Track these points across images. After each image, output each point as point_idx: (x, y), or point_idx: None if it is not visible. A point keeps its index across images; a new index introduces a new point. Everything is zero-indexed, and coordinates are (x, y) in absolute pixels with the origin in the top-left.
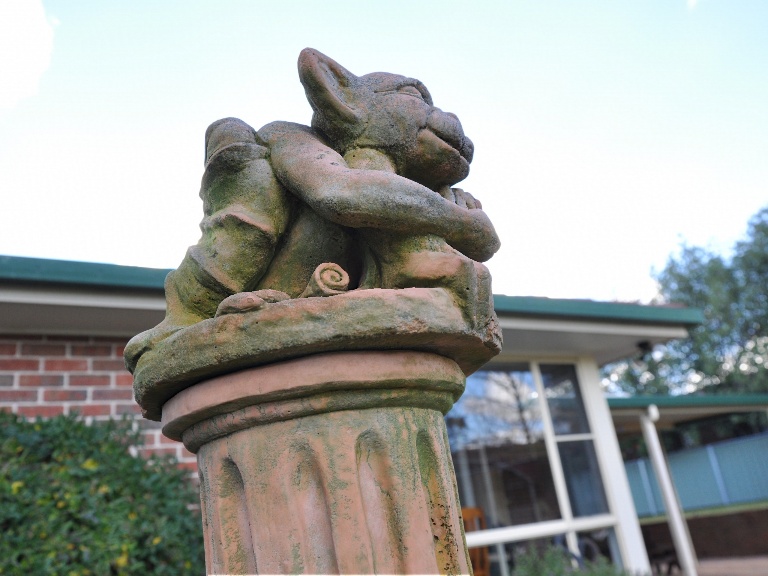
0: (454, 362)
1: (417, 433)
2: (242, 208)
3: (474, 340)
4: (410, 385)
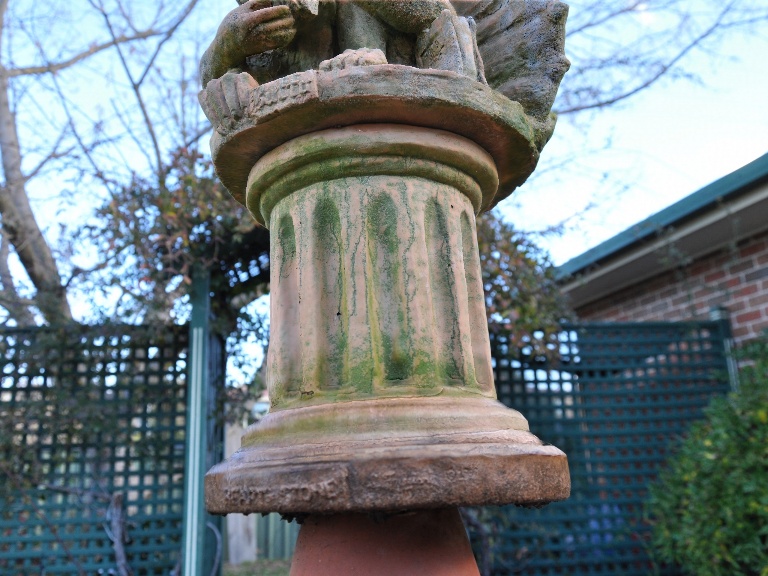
0: (287, 143)
1: (280, 220)
2: None
3: (246, 134)
4: (257, 192)
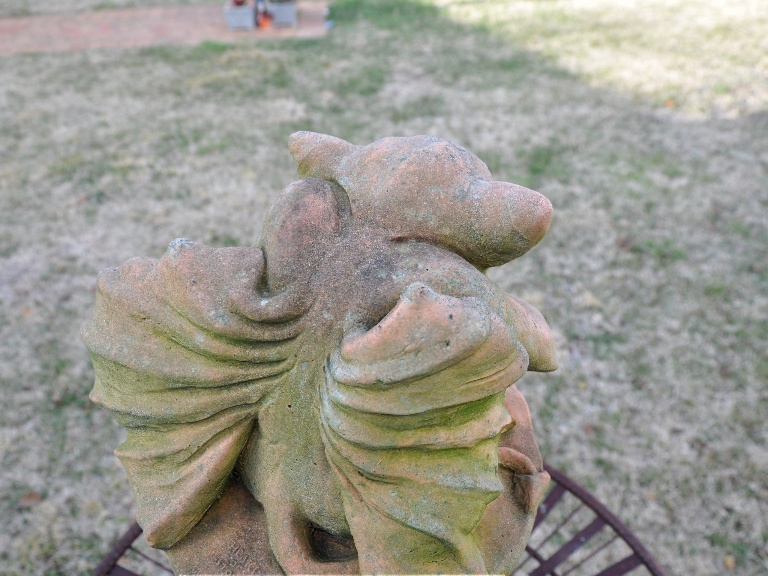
0: None
1: None
2: (499, 409)
3: None
4: None
